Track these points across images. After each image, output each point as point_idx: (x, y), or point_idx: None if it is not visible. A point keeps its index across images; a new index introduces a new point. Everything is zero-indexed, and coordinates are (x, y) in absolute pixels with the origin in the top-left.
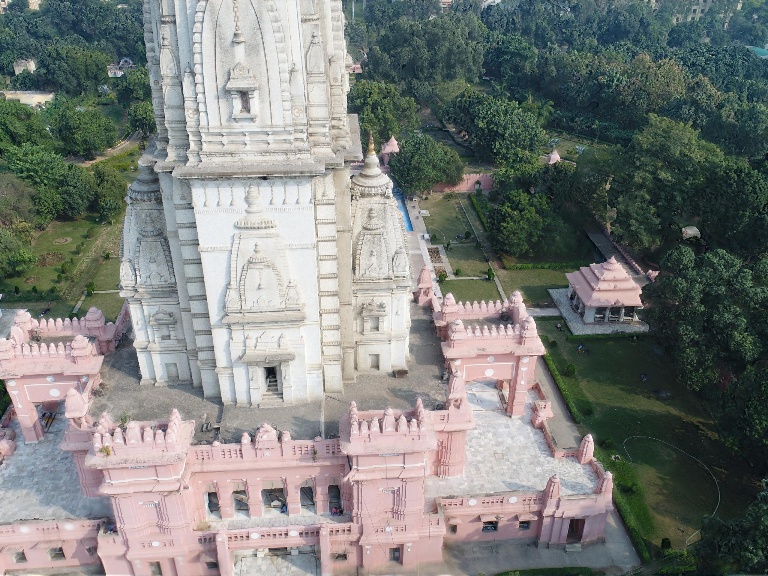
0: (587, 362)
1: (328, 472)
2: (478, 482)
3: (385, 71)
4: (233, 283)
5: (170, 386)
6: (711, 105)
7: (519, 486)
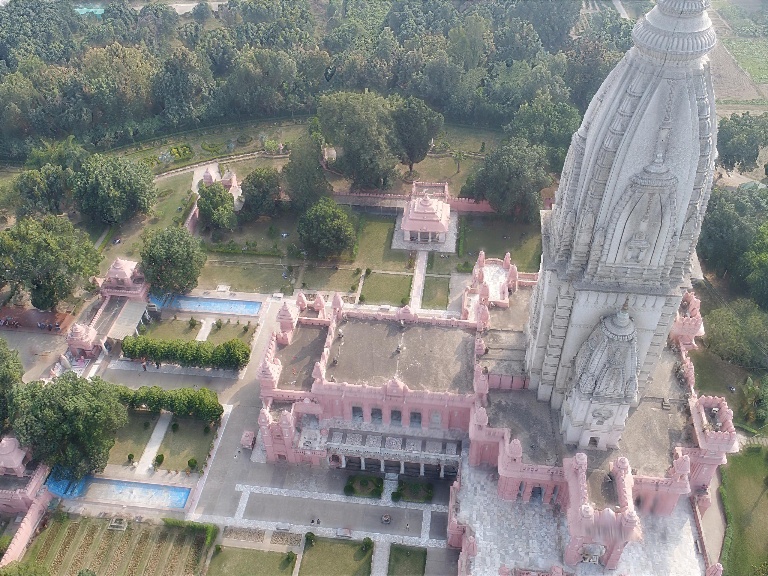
0: (487, 256)
1: None
2: None
3: None
4: None
5: None
6: (201, 65)
7: None
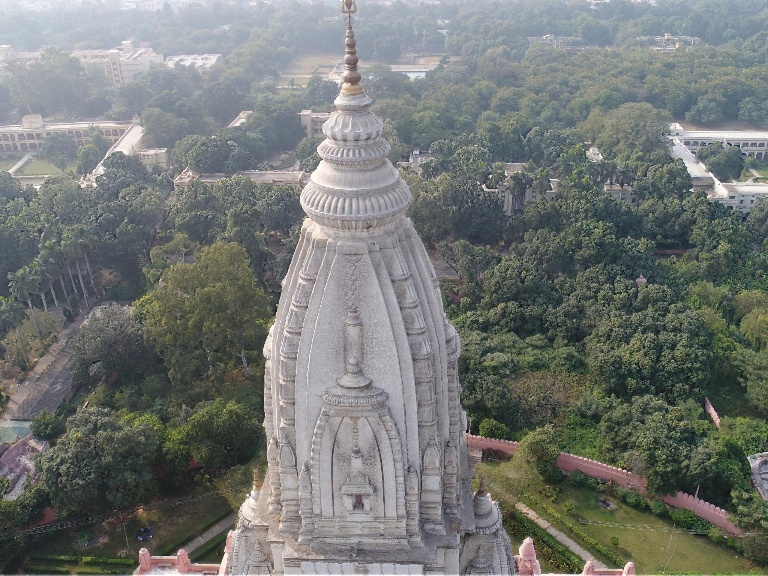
0: None
1: None
2: None
3: None
4: None
5: None
6: None
7: None
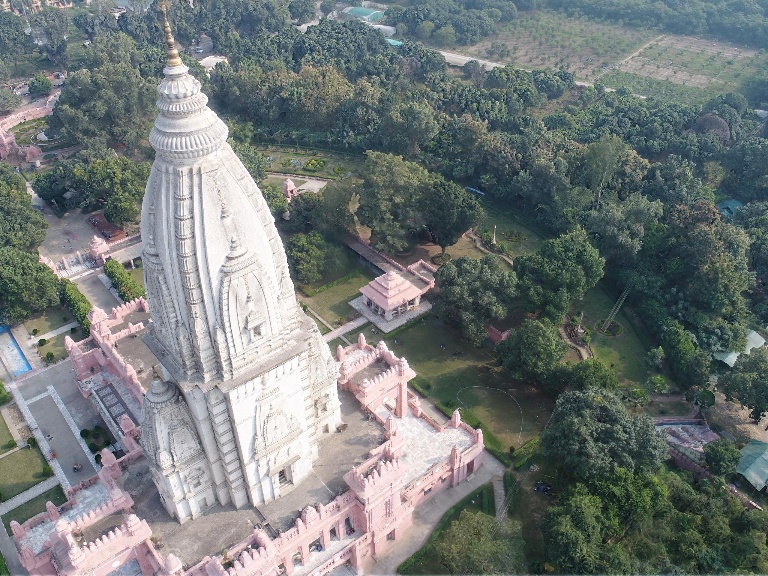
0: (406, 351)
1: (345, 513)
2: (412, 469)
3: (85, 128)
4: (259, 434)
5: (204, 514)
6: (376, 103)
7: (434, 460)
